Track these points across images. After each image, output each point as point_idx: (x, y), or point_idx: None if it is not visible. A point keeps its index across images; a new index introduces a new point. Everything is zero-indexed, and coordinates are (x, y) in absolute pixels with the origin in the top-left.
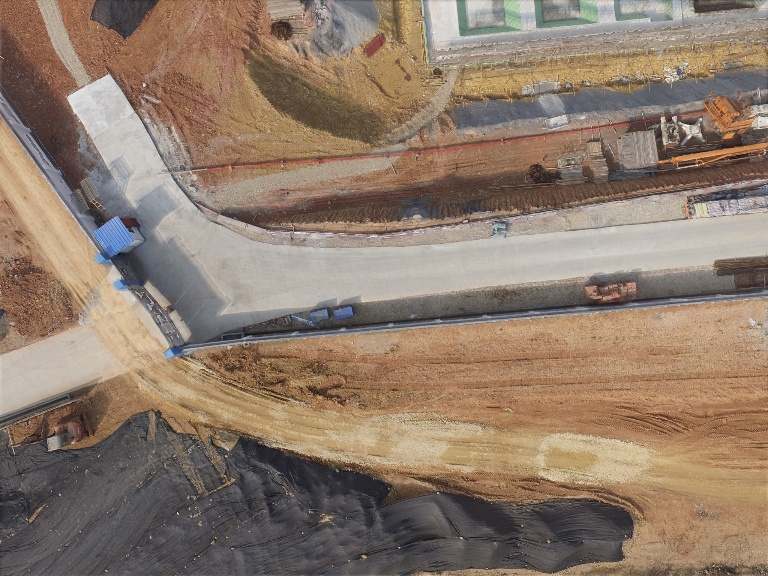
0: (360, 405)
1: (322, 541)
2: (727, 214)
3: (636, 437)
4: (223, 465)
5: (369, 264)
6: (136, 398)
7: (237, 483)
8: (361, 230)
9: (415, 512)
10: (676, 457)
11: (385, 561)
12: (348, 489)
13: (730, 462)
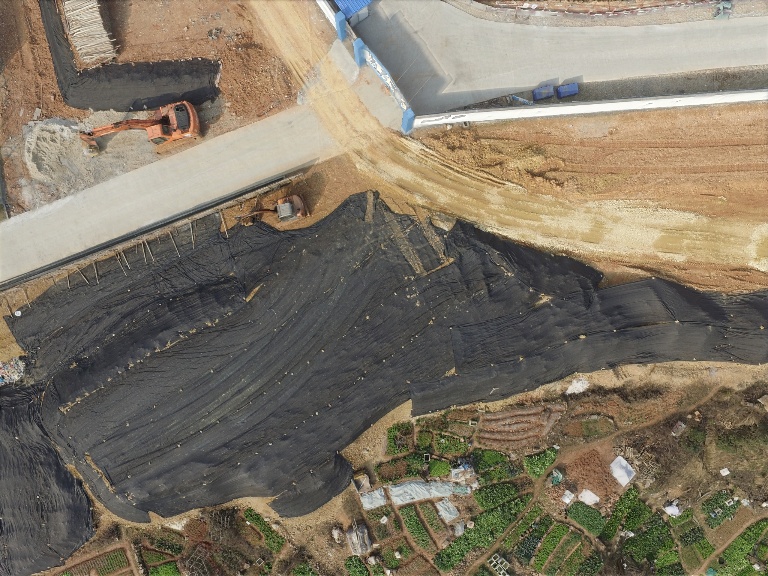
0: (578, 188)
1: (540, 322)
2: None
3: None
4: (441, 245)
5: (592, 43)
6: (354, 178)
7: (456, 263)
8: (584, 9)
9: (627, 299)
10: None
11: (601, 344)
12: (566, 270)
13: None
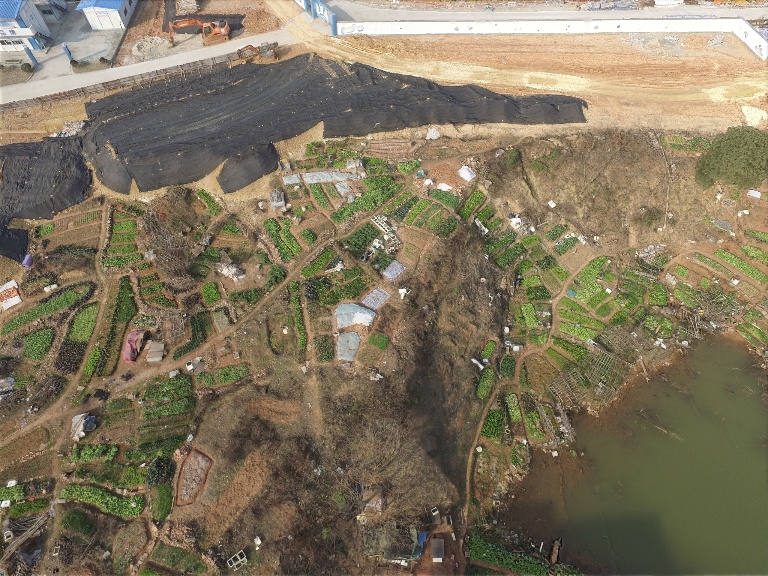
0: (424, 55)
1: None
2: (596, 7)
3: (577, 74)
4: None
5: (427, 15)
6: (304, 49)
7: (356, 73)
8: None
9: (456, 94)
10: (603, 82)
11: (440, 104)
12: None
13: (634, 85)
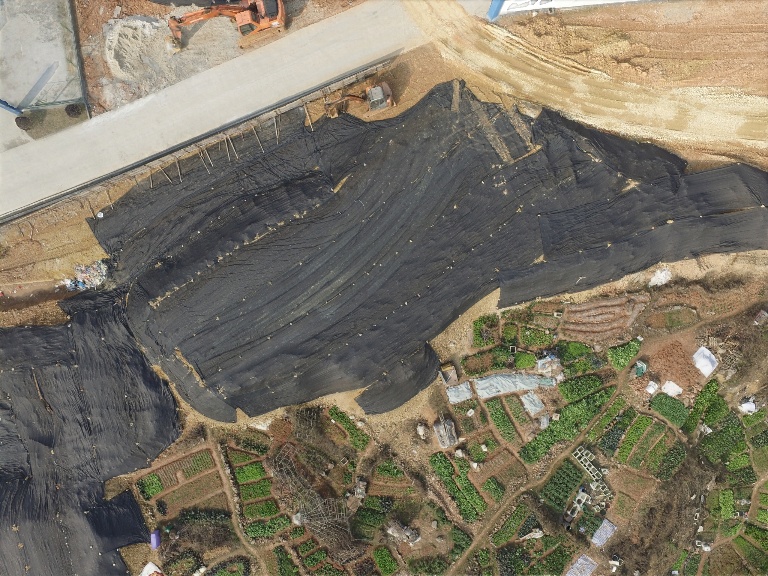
0: (663, 74)
1: (627, 208)
2: None
3: None
4: (528, 133)
5: None
6: (439, 68)
7: (543, 150)
8: None
9: (712, 186)
10: None
11: (687, 230)
12: (653, 156)
13: None
